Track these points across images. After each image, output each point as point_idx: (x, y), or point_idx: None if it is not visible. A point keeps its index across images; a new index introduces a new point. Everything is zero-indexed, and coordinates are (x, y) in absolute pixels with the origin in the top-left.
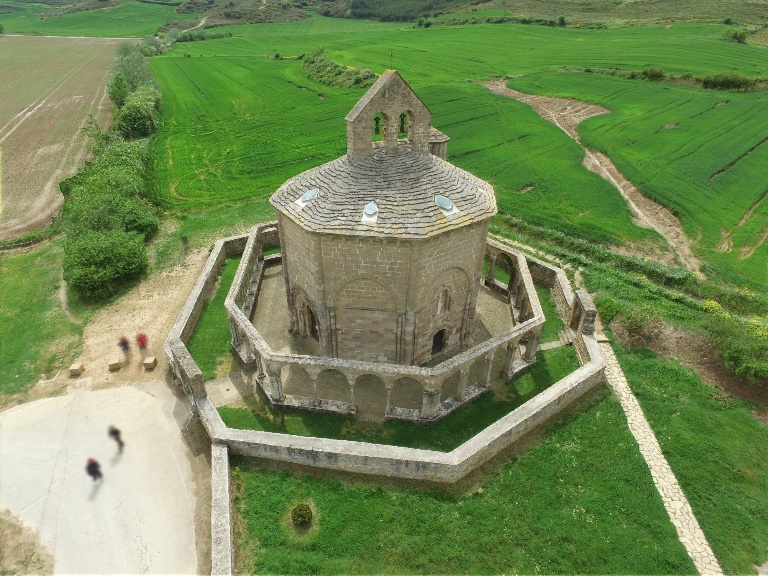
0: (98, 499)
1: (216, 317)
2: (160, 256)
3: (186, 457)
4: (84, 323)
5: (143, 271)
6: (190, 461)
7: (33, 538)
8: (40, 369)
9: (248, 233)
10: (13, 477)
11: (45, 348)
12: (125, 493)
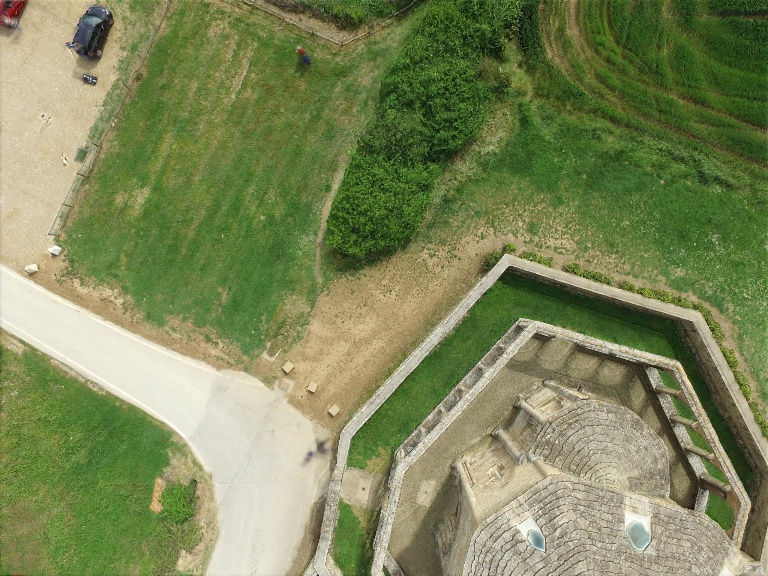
0: (250, 515)
1: (415, 387)
2: (441, 210)
3: (304, 529)
4: (321, 288)
5: (407, 236)
6: (304, 534)
7: (215, 511)
8: (269, 334)
9: (548, 268)
10: (220, 451)
11: (282, 304)
12: (263, 525)
